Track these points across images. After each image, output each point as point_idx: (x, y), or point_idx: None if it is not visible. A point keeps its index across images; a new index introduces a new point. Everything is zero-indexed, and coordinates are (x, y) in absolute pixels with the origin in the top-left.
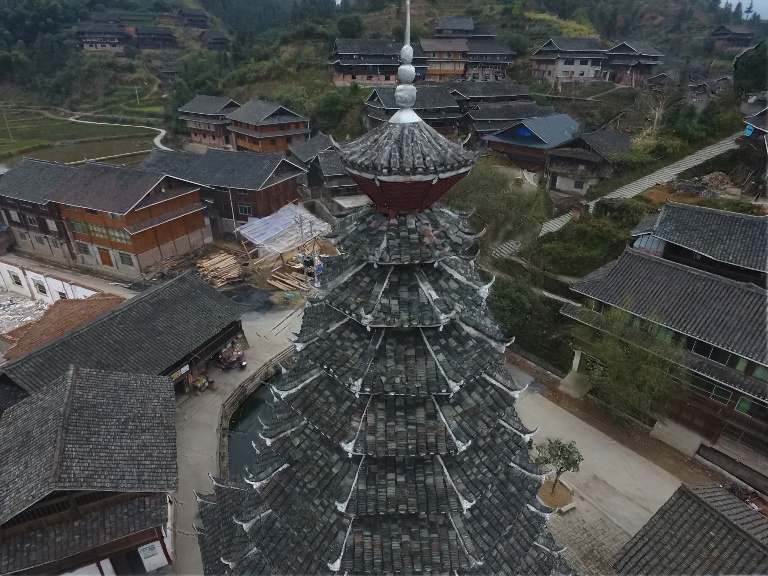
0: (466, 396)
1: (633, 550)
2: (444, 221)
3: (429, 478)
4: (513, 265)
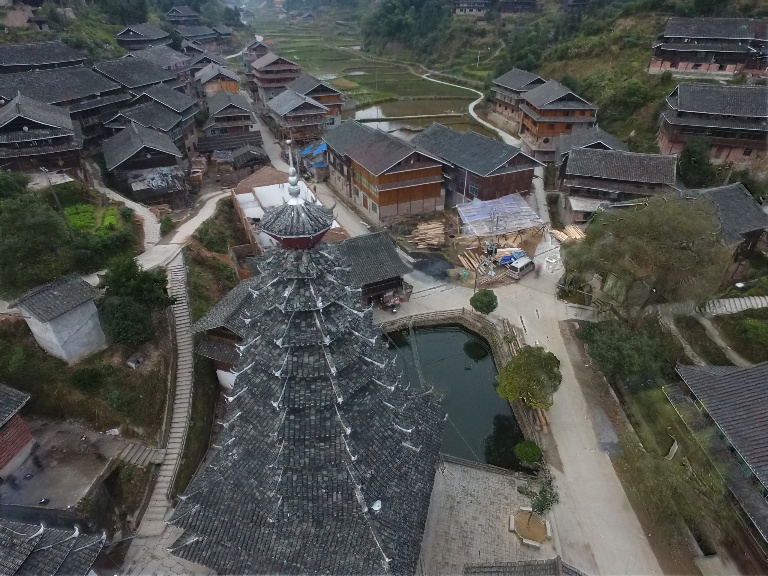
0: (305, 356)
1: (486, 568)
2: (305, 259)
3: (274, 385)
4: (696, 327)
